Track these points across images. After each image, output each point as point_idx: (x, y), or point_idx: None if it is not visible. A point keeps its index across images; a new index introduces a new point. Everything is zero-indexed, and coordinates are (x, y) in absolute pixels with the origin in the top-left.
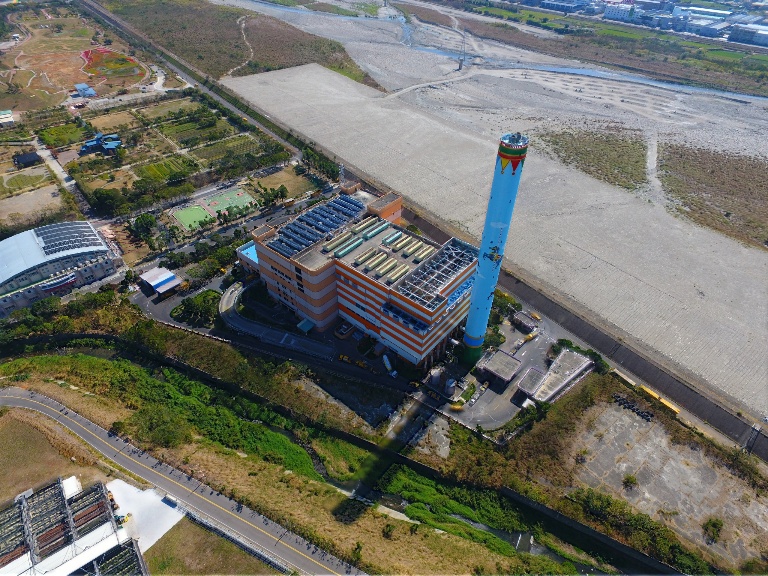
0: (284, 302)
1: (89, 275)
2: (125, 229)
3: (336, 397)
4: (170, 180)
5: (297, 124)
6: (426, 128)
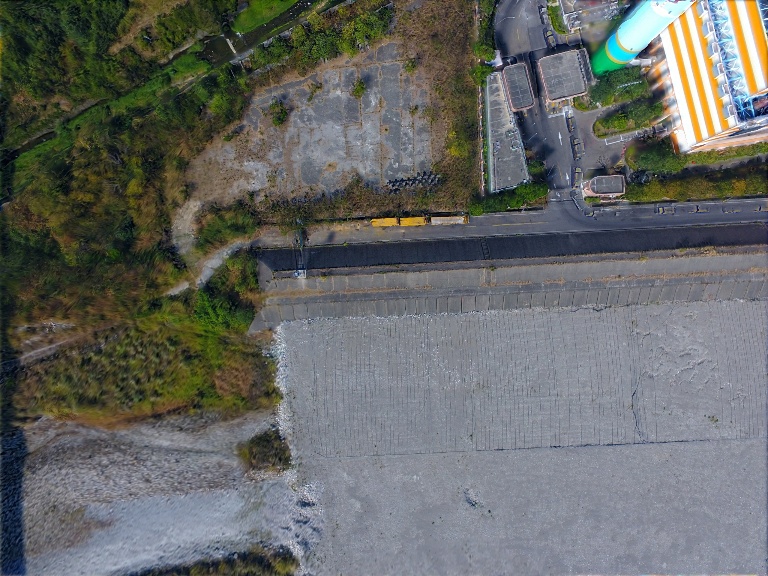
0: None
1: None
2: None
3: None
4: None
5: None
6: None
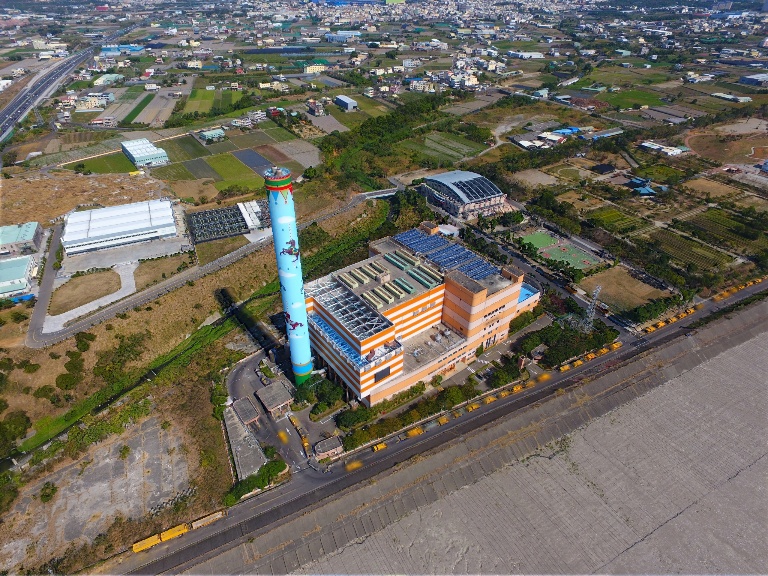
0: None
1: (449, 207)
2: None
3: None
4: (587, 220)
5: None
6: None
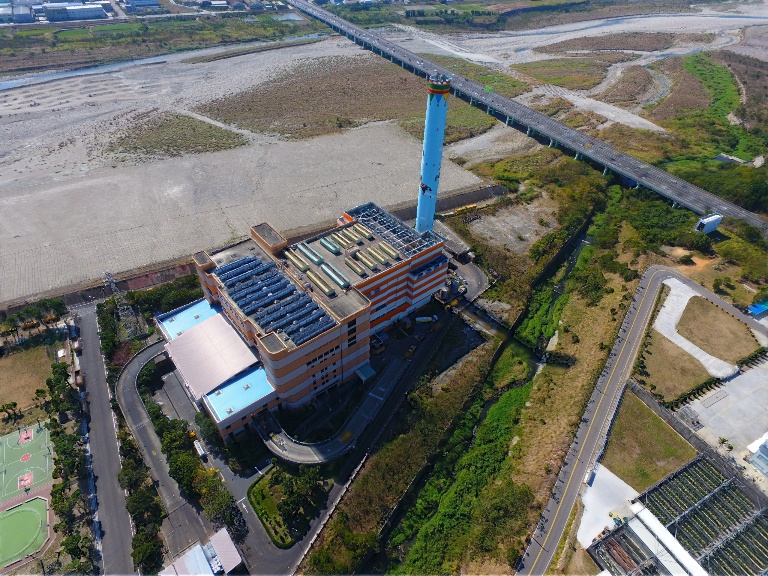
0: (322, 389)
1: None
2: None
3: (455, 362)
4: None
5: None
6: None
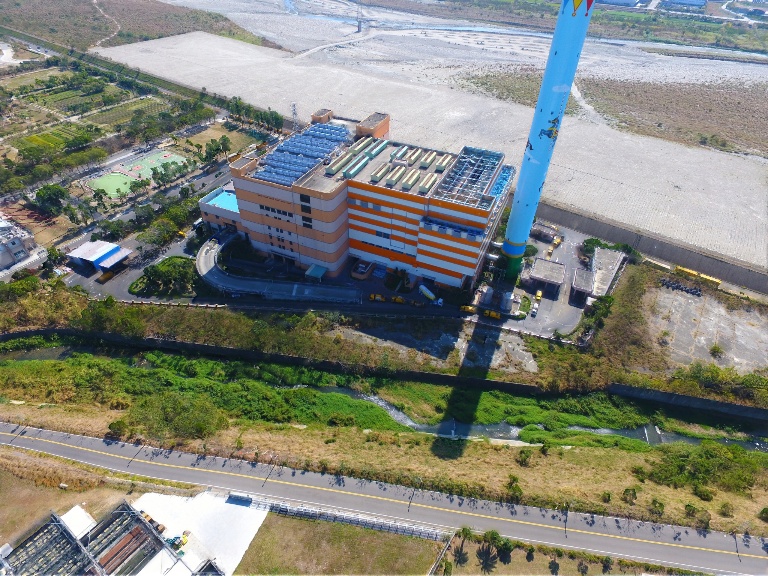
0: (278, 252)
1: None
2: (22, 208)
3: (386, 338)
4: (68, 147)
5: (206, 86)
6: (352, 80)
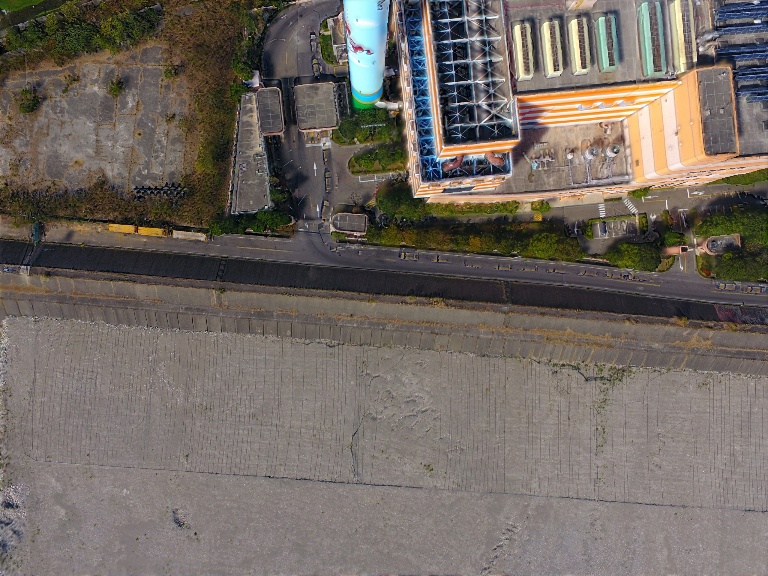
0: None
1: None
2: None
3: None
4: None
5: None
6: None
